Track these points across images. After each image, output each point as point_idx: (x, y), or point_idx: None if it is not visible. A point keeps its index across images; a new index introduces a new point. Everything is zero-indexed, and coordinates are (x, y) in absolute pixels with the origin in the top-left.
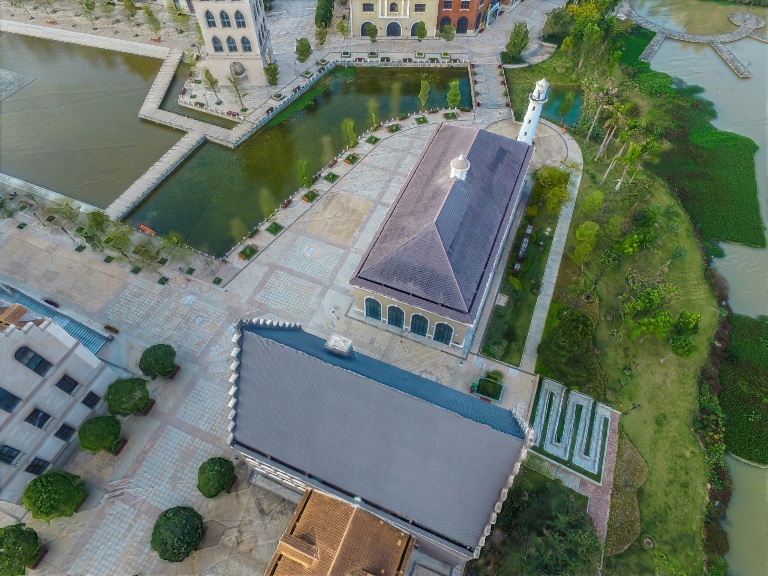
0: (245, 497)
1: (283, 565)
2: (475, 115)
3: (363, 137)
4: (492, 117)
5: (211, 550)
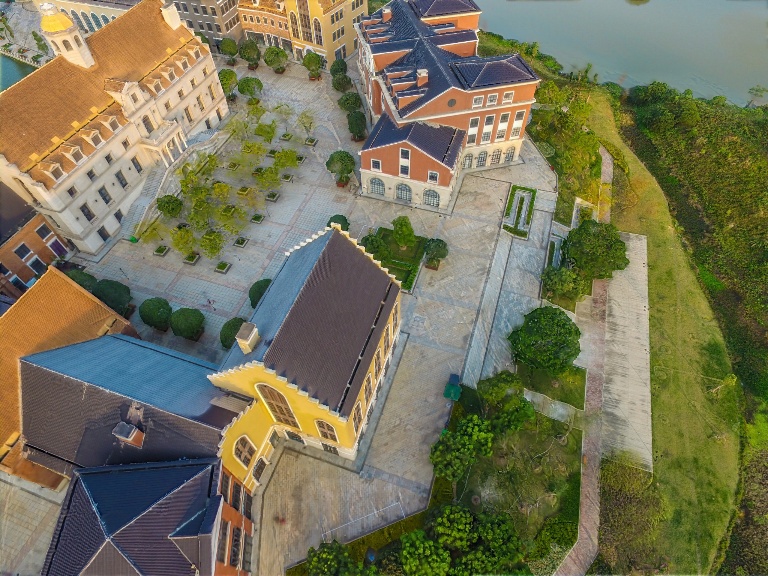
0: (240, 59)
1: (262, 5)
2: (10, 13)
3: (1, 49)
4: (17, 8)
5: (259, 63)
